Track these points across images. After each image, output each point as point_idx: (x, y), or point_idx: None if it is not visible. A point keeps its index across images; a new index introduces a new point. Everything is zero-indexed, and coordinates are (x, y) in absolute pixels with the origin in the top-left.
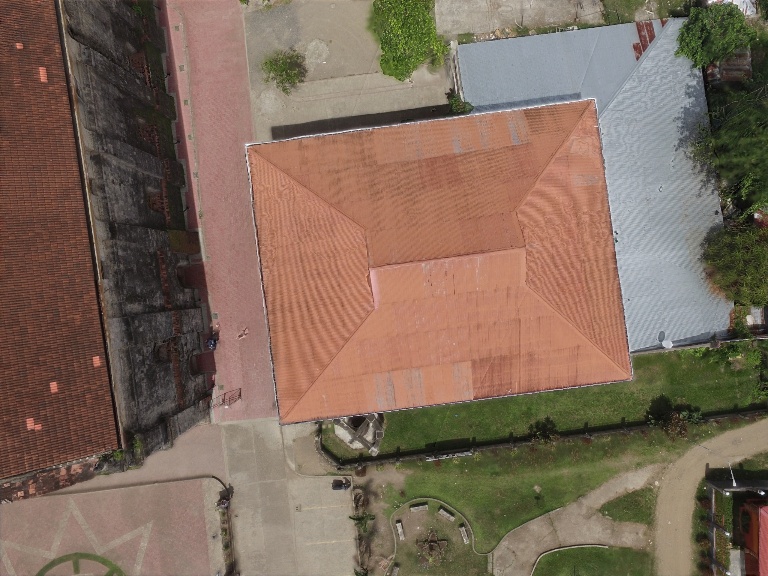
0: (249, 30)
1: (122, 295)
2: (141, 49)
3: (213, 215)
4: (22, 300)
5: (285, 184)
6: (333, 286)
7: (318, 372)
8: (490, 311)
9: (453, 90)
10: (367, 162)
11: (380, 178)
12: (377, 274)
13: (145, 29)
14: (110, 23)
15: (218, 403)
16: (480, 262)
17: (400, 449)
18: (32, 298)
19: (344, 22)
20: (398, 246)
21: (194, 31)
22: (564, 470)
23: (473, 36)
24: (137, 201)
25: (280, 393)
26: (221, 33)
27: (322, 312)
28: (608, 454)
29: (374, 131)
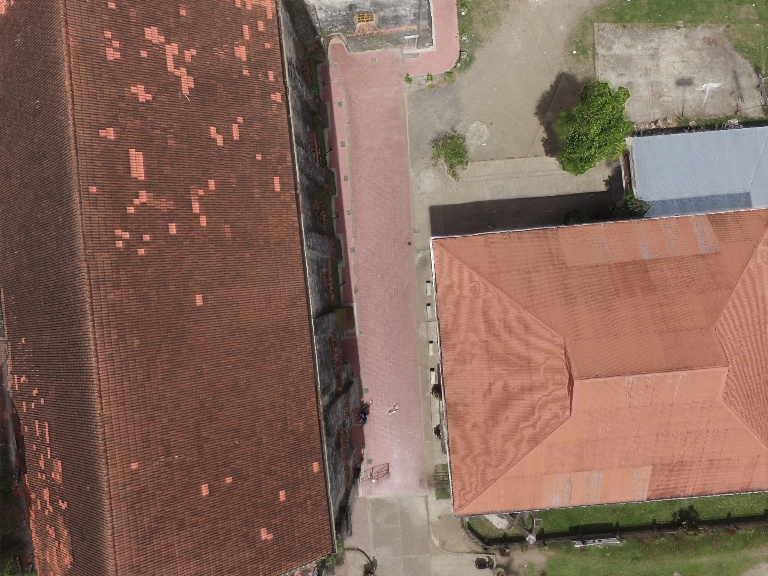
0: (411, 109)
1: (320, 390)
2: (313, 128)
3: (368, 290)
4: (259, 411)
5: (473, 281)
6: (523, 388)
7: (502, 470)
8: (681, 422)
9: (612, 178)
10: (556, 264)
11: (572, 282)
12: (580, 386)
13: (317, 108)
14: (300, 111)
15: (366, 477)
16: (682, 378)
17: (544, 530)
18: (267, 408)
19: (505, 105)
20: (600, 358)
21: (356, 107)
22: (704, 558)
23: (633, 125)
24: (319, 287)
25: (456, 485)
26: (383, 111)
27: (509, 412)
28: (749, 545)
29: (558, 230)
